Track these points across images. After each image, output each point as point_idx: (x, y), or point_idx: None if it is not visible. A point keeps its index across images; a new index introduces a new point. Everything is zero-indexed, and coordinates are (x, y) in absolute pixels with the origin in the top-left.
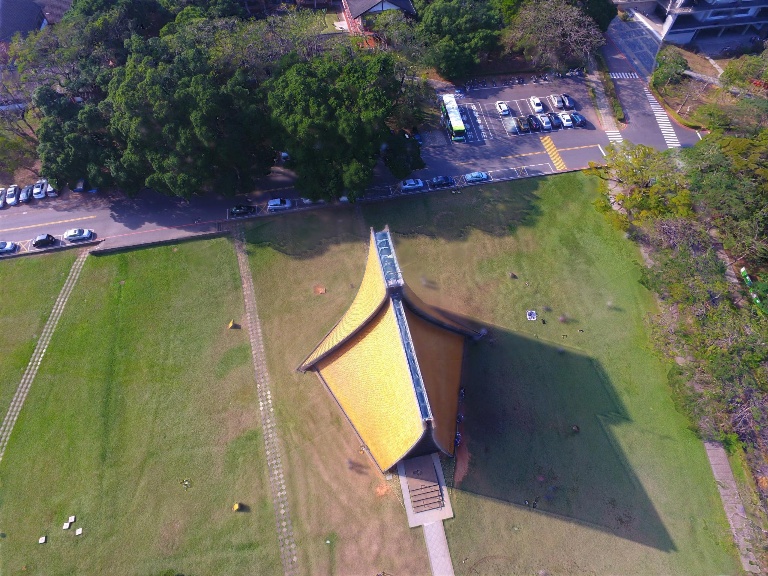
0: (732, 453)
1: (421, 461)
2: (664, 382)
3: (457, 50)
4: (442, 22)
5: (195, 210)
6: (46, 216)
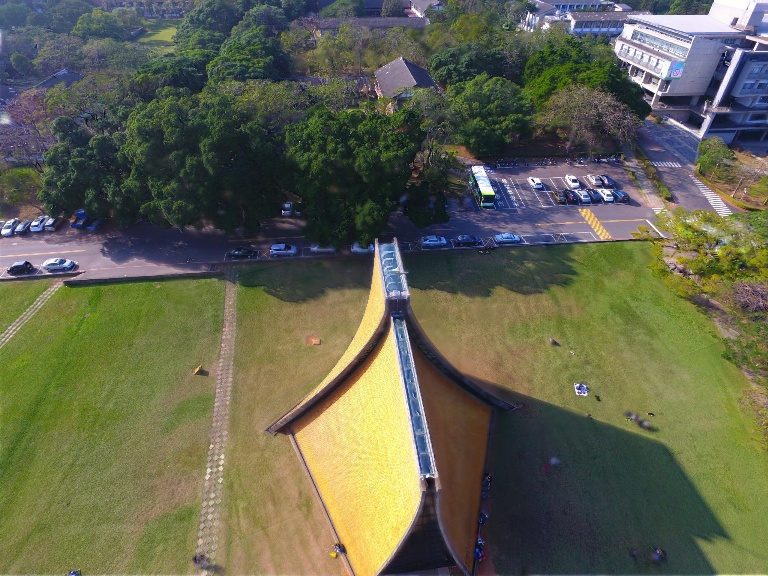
0: None
1: None
2: None
3: (487, 129)
4: (473, 106)
5: (191, 250)
6: (35, 247)
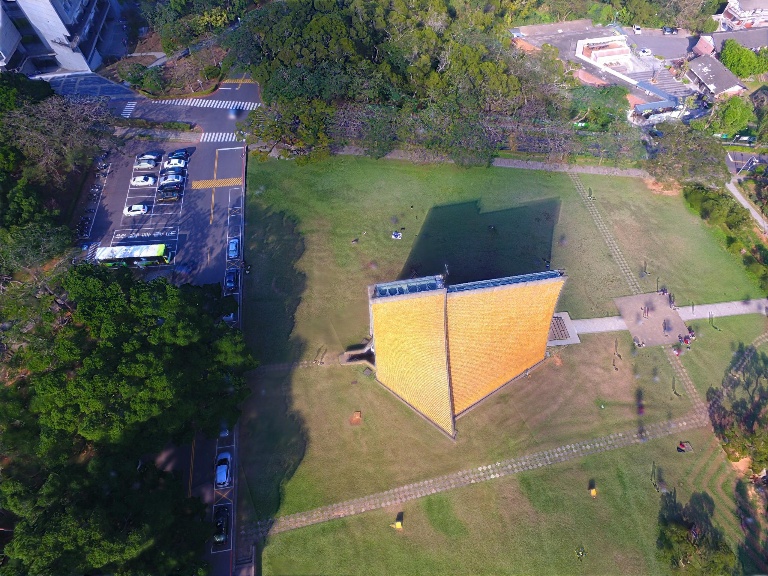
0: (497, 155)
1: None
2: (452, 172)
3: None
4: None
5: None
6: None
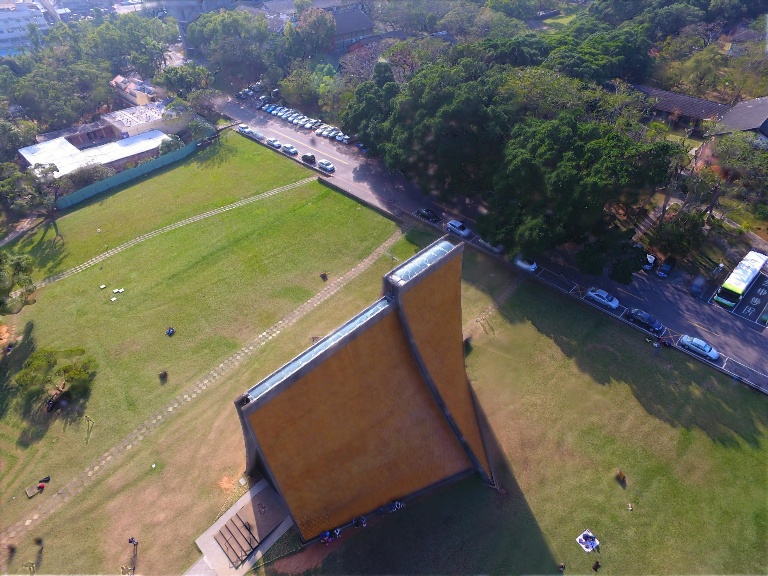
0: None
1: (278, 505)
2: None
3: None
4: None
5: (401, 195)
6: (328, 149)
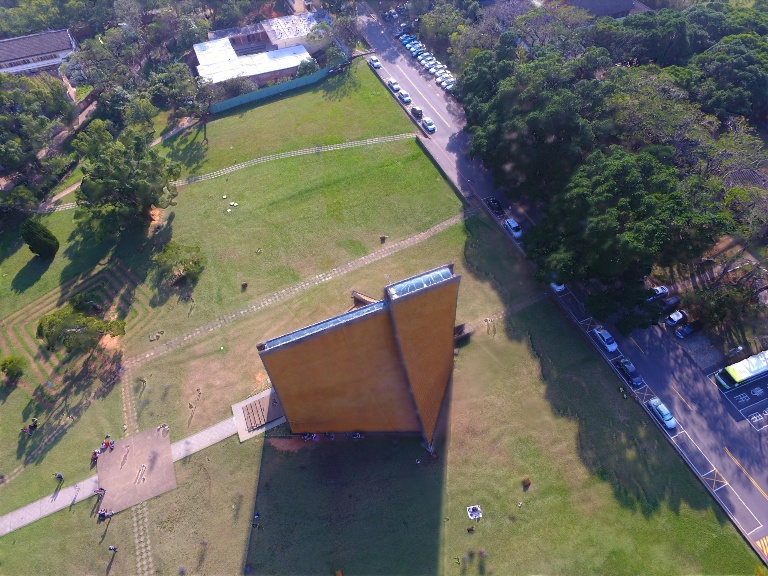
0: None
1: None
2: None
3: None
4: None
5: (481, 176)
6: (439, 104)
